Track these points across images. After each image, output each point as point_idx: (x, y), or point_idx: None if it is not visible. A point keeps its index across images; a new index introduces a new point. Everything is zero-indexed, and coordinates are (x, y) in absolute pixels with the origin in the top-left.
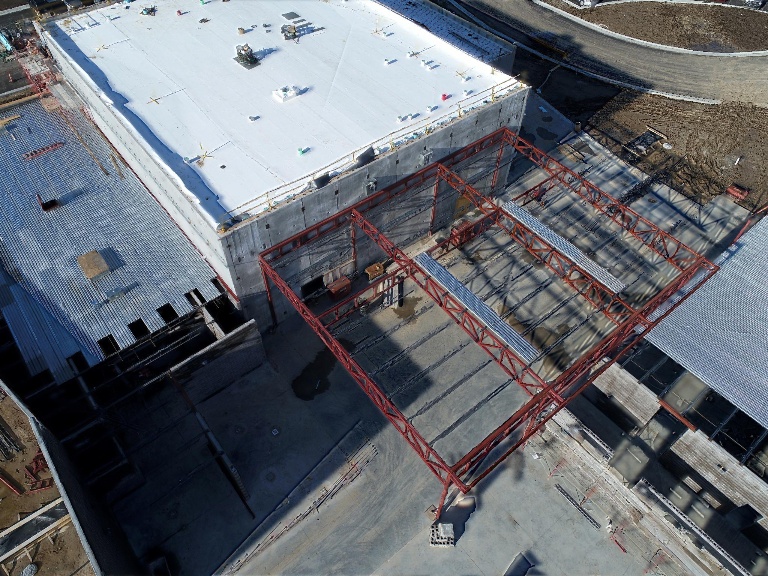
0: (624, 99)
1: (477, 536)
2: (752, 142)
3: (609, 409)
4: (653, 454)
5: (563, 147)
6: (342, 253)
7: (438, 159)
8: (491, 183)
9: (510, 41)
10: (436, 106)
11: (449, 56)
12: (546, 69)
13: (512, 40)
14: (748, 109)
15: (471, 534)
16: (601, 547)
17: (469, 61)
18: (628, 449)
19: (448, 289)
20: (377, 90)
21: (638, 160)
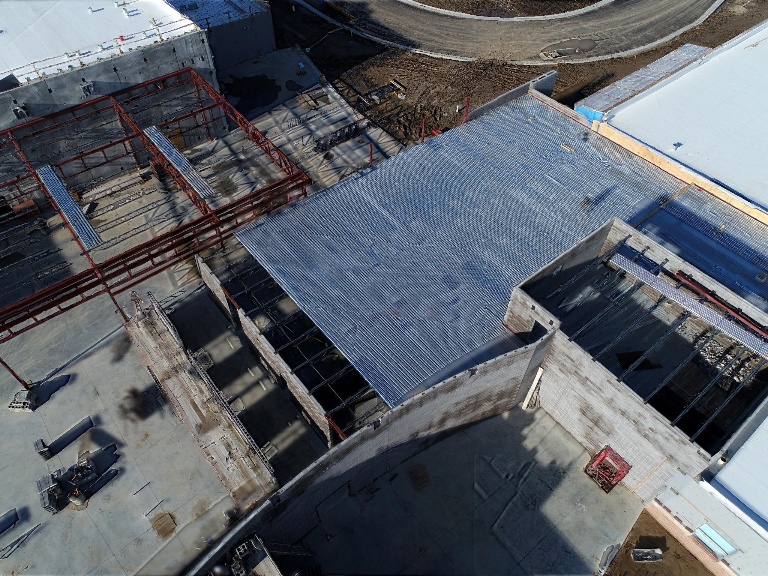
0: (385, 57)
1: (57, 404)
2: (484, 93)
3: (219, 305)
4: (247, 342)
5: (301, 96)
6: (20, 176)
7: (109, 92)
8: None
9: (306, 7)
10: (111, 46)
11: (155, 6)
12: (326, 31)
13: (309, 6)
14: (497, 65)
15: (53, 402)
16: (162, 412)
17: (168, 9)
18: (227, 338)
19: (52, 194)
20: (67, 33)
21: (368, 108)
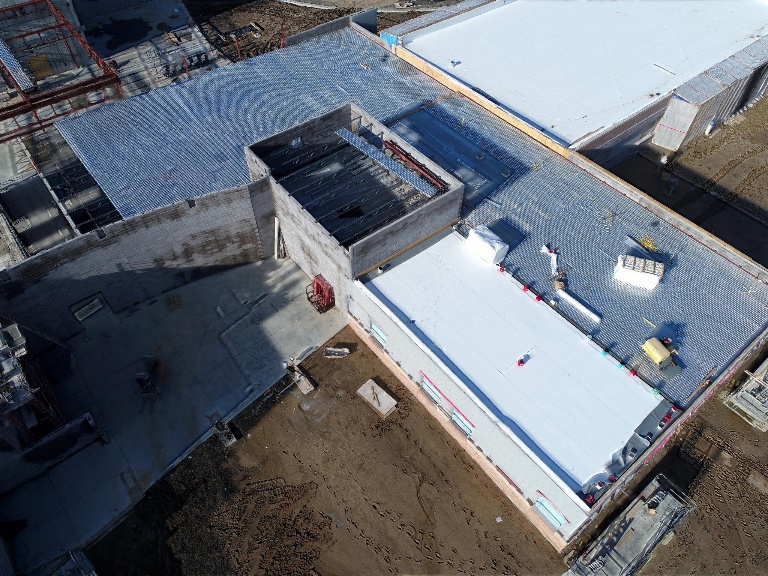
0: (254, 5)
1: None
2: None
3: None
4: None
5: (167, 34)
6: None
7: None
8: (68, 51)
9: None
10: None
11: None
12: None
13: None
14: (353, 12)
15: None
16: None
17: None
18: (48, 209)
19: None
20: None
21: (224, 44)
